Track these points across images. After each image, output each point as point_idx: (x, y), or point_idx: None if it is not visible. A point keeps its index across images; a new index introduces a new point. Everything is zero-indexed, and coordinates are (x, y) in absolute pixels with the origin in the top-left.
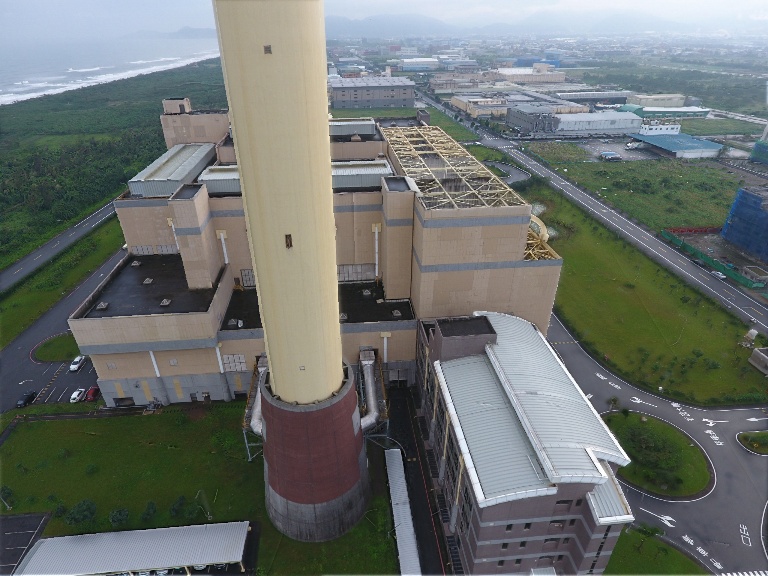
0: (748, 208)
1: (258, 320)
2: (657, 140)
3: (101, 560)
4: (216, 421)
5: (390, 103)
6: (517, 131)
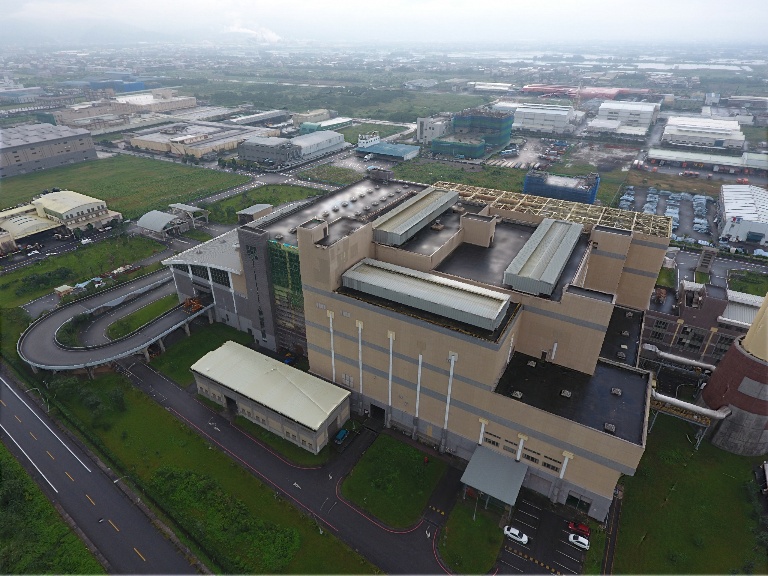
0: (535, 185)
1: None
2: (379, 150)
3: None
4: (645, 456)
5: (67, 159)
6: (269, 163)
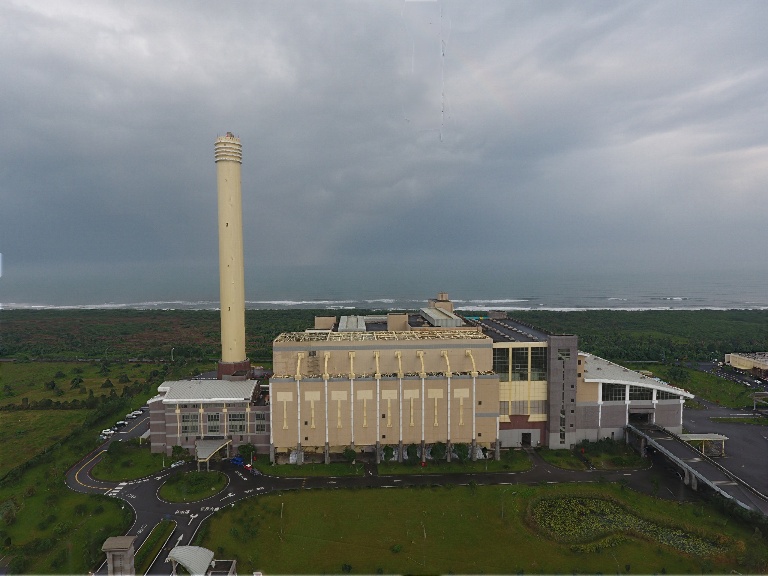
0: None
1: None
2: None
3: None
4: None
5: None
6: None
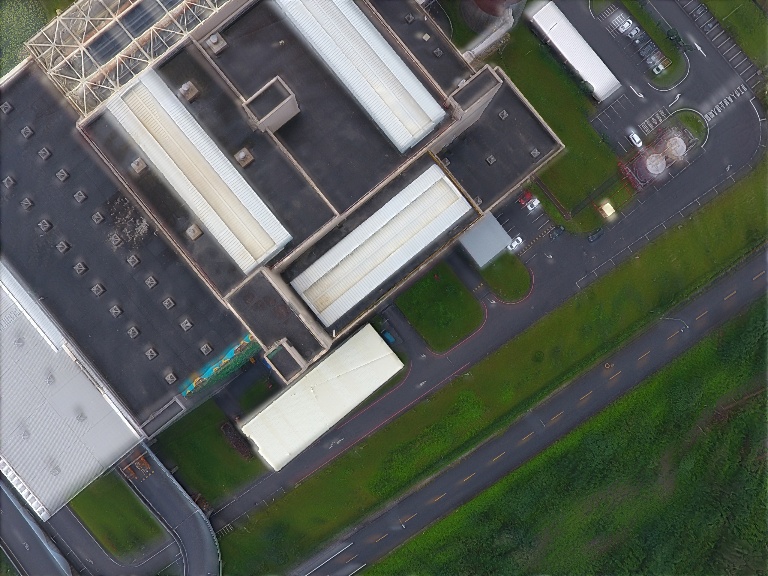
0: None
1: (451, 74)
2: None
3: (591, 59)
4: None
5: None
6: None
